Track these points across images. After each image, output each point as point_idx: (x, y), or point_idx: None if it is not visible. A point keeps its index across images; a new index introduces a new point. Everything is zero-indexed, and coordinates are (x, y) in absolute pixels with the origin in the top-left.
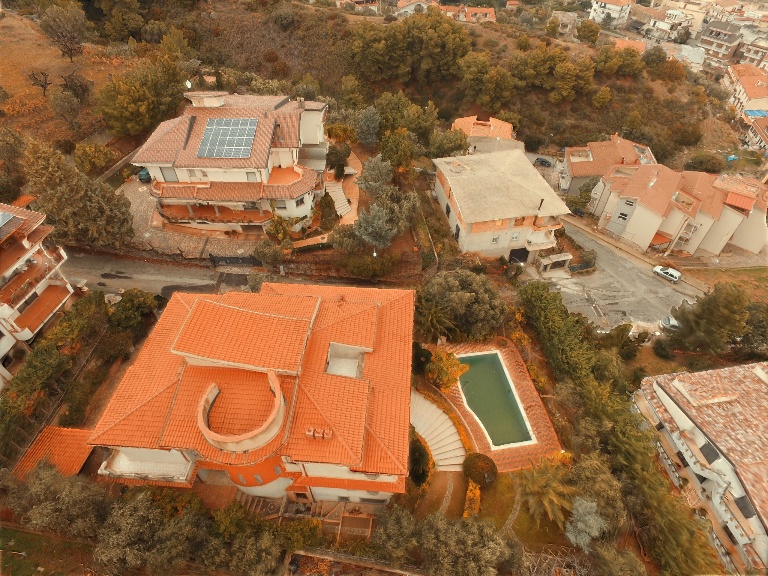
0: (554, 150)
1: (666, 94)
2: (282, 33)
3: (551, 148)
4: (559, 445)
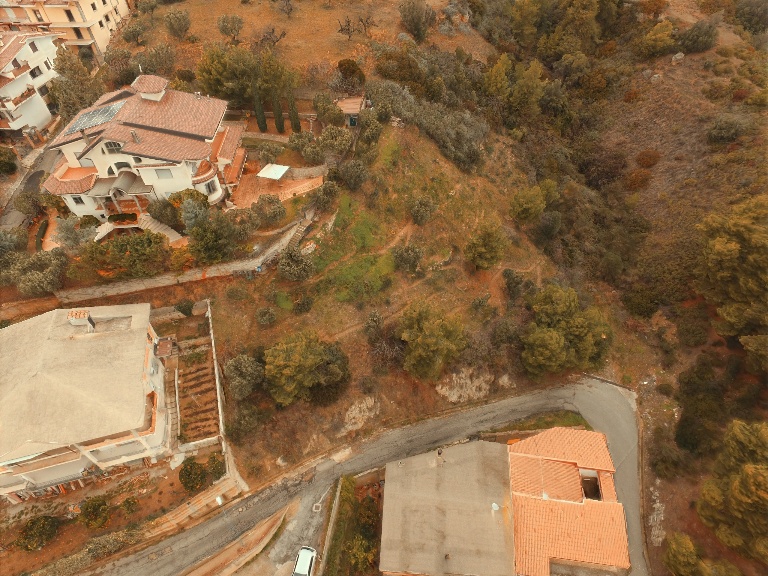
0: None
1: None
2: (704, 144)
3: None
4: None
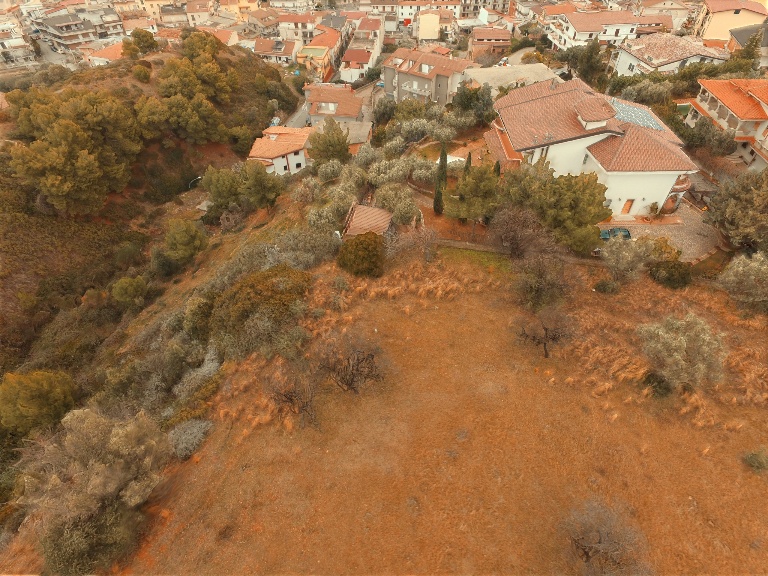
0: None
1: (234, 57)
2: None
3: None
4: None
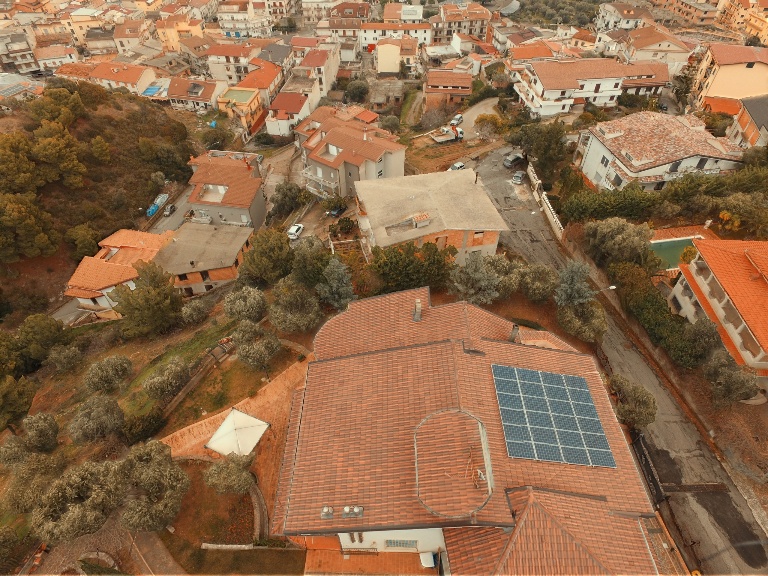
0: (144, 223)
1: (120, 113)
2: None
3: (140, 224)
4: (696, 226)
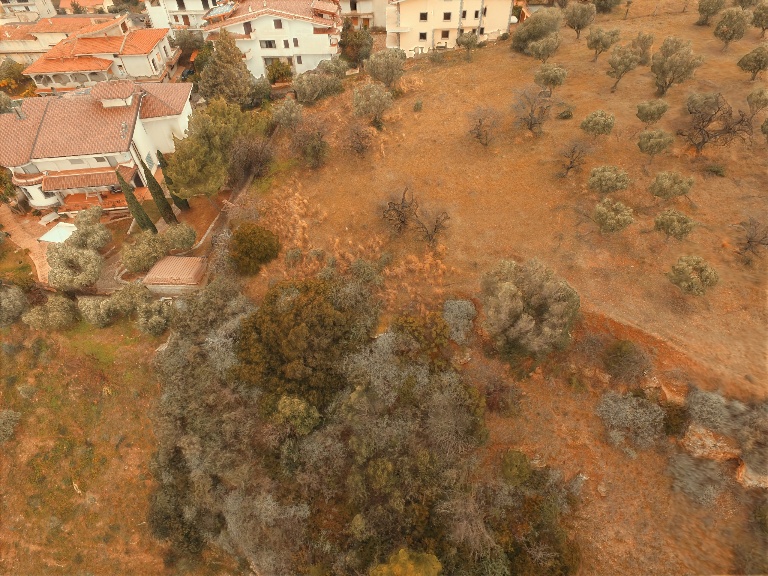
0: None
1: None
2: None
3: None
4: None
